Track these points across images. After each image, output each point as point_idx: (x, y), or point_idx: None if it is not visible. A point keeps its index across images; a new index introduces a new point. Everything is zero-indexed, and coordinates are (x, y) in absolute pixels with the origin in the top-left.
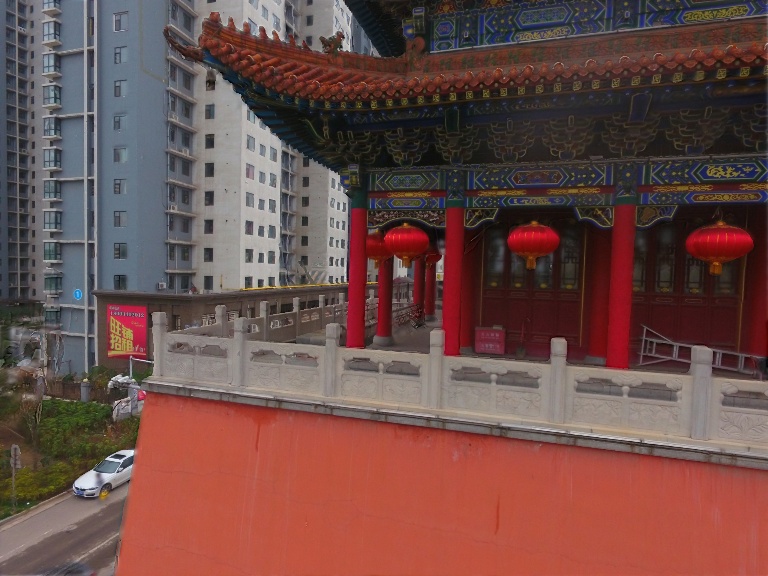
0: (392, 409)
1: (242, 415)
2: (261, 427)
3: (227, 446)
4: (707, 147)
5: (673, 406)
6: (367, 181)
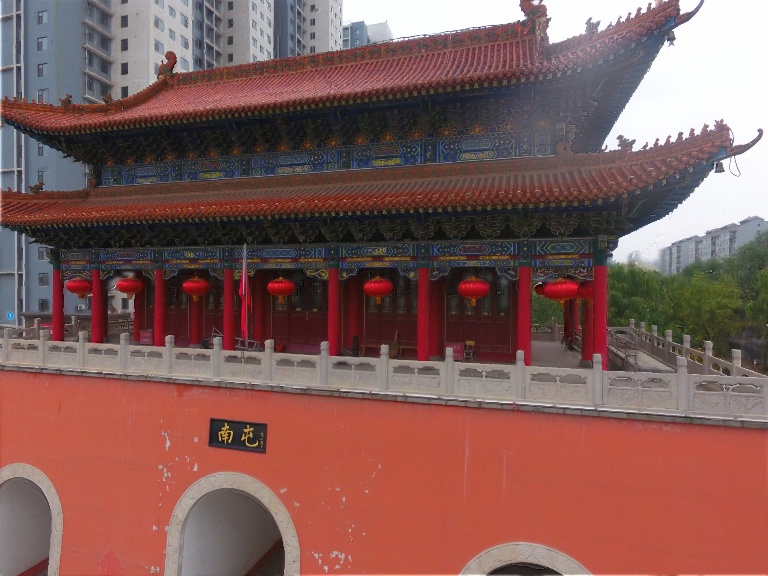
0: (24, 365)
1: None
2: None
3: None
4: (187, 243)
5: (116, 357)
6: (59, 256)
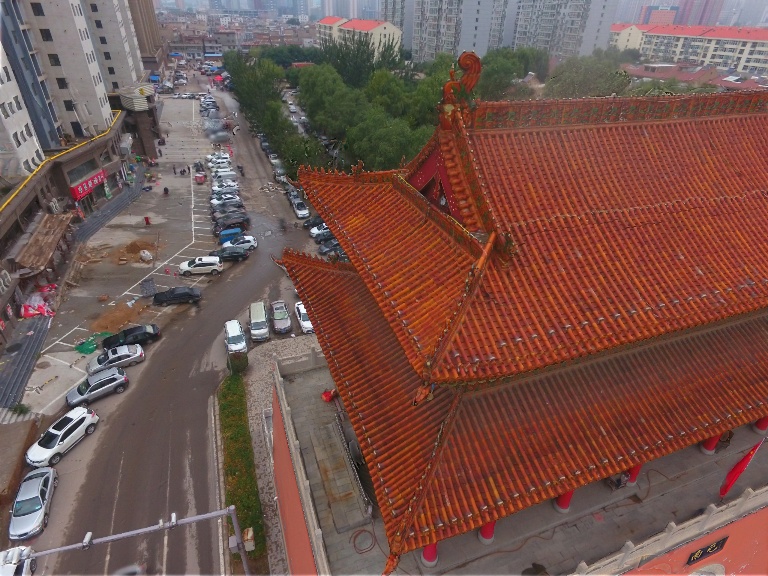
0: None
1: None
2: None
3: None
4: None
5: None
6: None
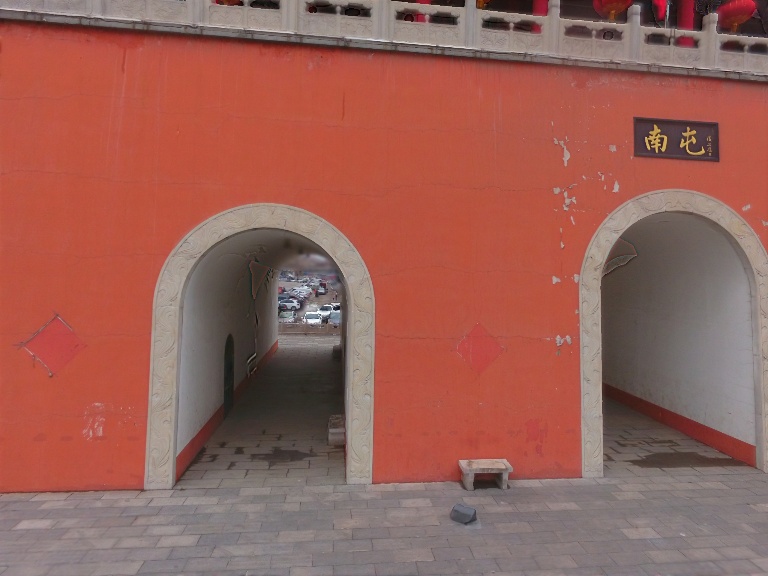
0: (257, 28)
1: (105, 41)
2: (127, 51)
3: (88, 71)
4: None
5: (455, 27)
6: None
